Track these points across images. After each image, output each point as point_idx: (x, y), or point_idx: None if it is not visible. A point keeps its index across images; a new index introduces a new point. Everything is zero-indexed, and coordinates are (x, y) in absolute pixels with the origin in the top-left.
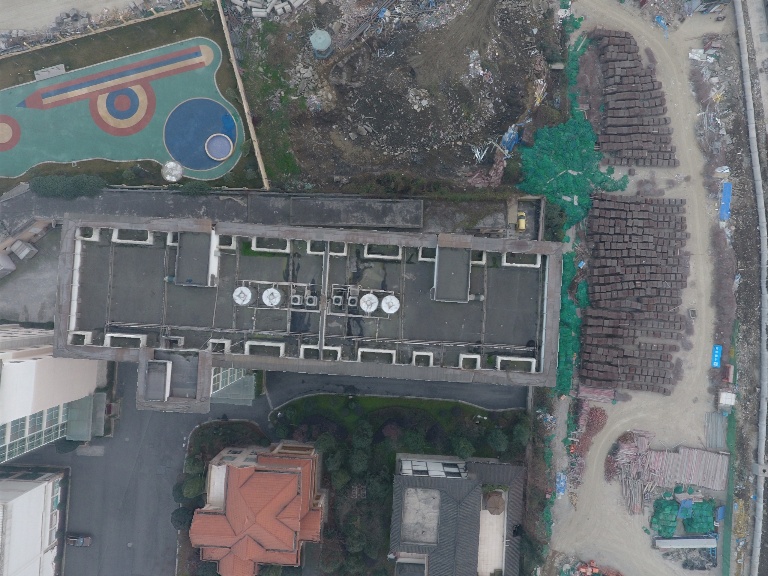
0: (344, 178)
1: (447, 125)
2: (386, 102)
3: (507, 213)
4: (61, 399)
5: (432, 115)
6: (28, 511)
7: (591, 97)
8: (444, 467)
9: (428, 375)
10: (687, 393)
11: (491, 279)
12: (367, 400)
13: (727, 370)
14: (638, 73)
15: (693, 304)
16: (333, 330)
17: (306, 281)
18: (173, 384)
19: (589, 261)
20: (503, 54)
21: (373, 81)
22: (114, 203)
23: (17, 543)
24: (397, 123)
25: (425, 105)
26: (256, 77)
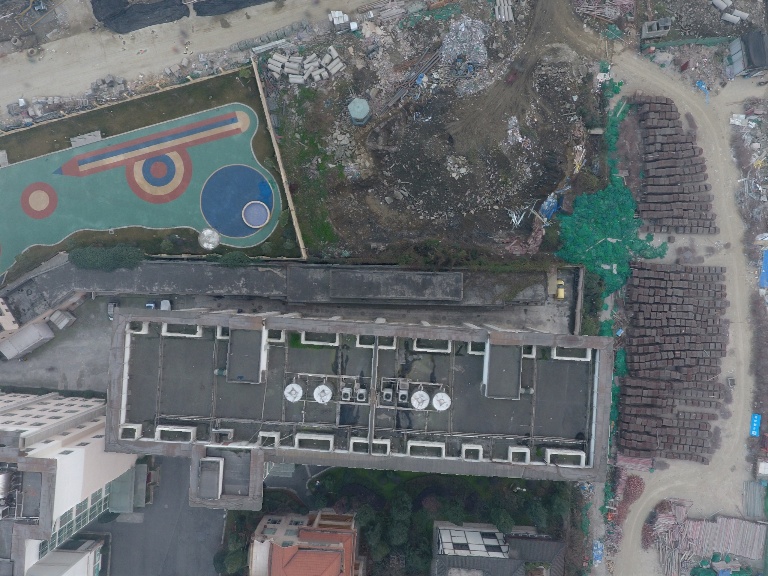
0: (381, 245)
1: (484, 190)
2: (424, 169)
3: (547, 285)
4: (107, 479)
5: (470, 182)
6: None
7: (630, 163)
8: (483, 538)
9: (478, 470)
10: (725, 462)
11: (540, 371)
12: None
13: (766, 440)
14: (679, 140)
15: (732, 372)
16: (382, 422)
17: (355, 373)
18: (225, 481)
19: (628, 330)
20: (542, 120)
21: (410, 147)
22: (153, 275)
23: None
24: (434, 189)
25: (463, 173)
26: (293, 143)
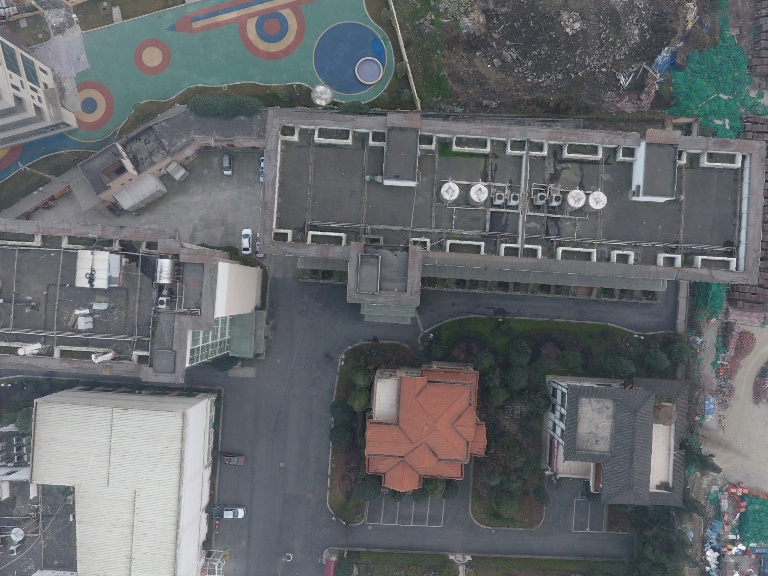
0: (493, 102)
1: (593, 51)
2: (537, 25)
3: None
4: (239, 308)
5: (582, 39)
6: (197, 423)
7: (741, 21)
8: None
9: (631, 272)
10: None
11: (688, 180)
12: (517, 323)
13: None
14: None
15: None
16: (531, 230)
17: (504, 181)
18: (382, 278)
19: None
20: None
21: (522, 5)
22: None
23: (191, 453)
24: (546, 47)
25: (577, 28)
26: (405, 1)
